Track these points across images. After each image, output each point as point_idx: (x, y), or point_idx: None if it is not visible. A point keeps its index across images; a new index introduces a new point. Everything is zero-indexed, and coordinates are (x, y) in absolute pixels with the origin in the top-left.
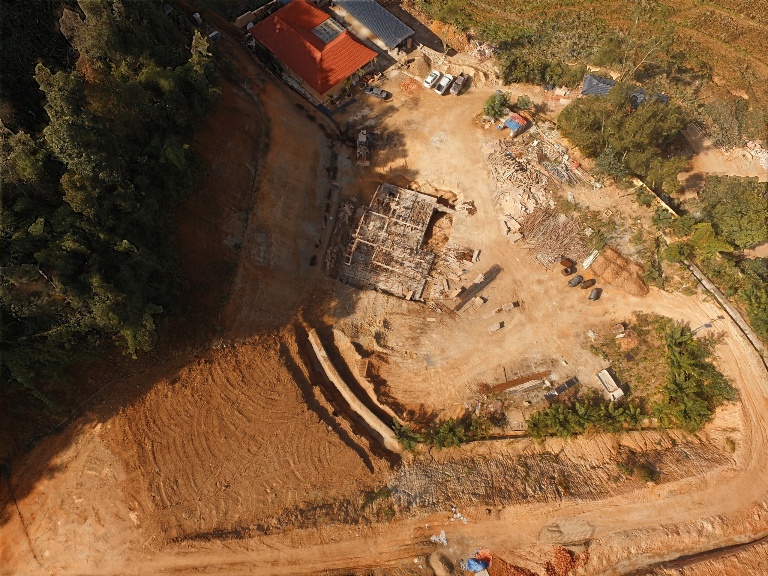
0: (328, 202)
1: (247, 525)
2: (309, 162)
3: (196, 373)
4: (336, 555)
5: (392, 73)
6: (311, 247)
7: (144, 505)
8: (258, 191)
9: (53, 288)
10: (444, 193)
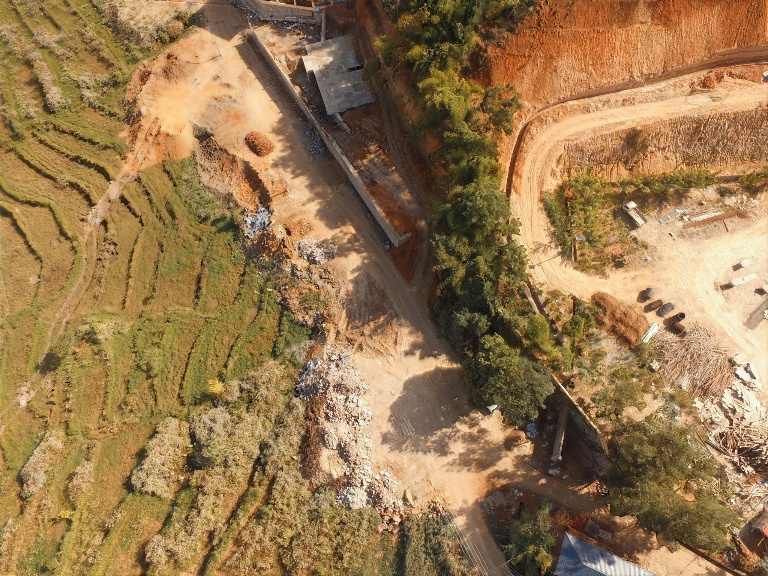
0: None
1: None
2: None
3: None
4: None
5: None
6: None
7: None
8: None
9: None
10: None
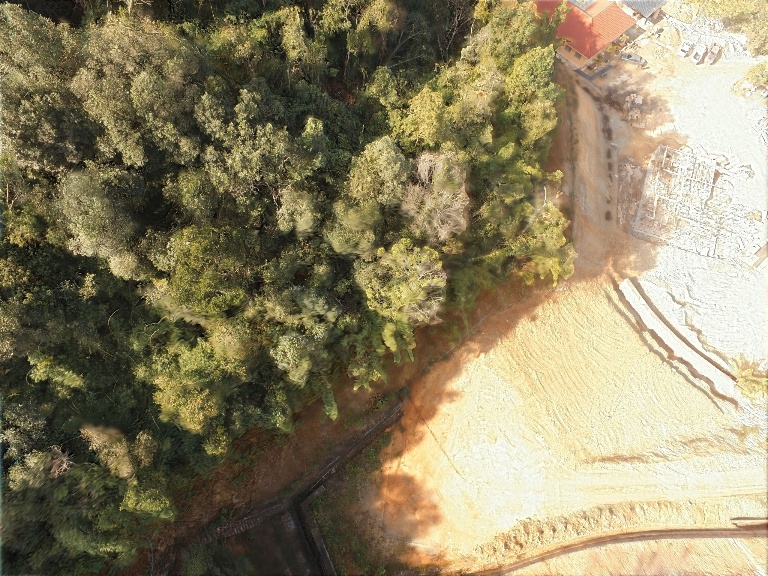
0: (609, 161)
1: (640, 452)
2: (594, 121)
3: (549, 312)
4: (740, 482)
5: (643, 42)
6: (605, 202)
7: (547, 429)
8: (578, 143)
9: (527, 209)
10: (717, 157)
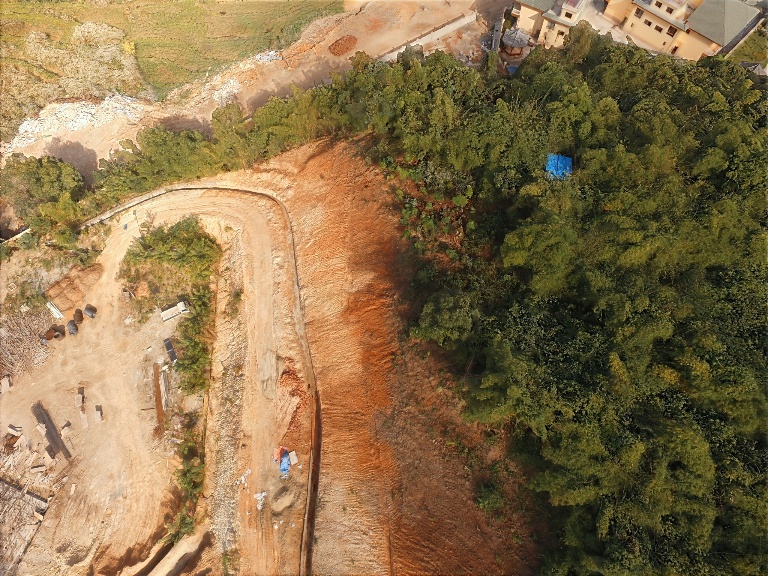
0: None
1: None
2: None
3: None
4: None
5: None
6: None
7: None
8: None
9: None
10: None
